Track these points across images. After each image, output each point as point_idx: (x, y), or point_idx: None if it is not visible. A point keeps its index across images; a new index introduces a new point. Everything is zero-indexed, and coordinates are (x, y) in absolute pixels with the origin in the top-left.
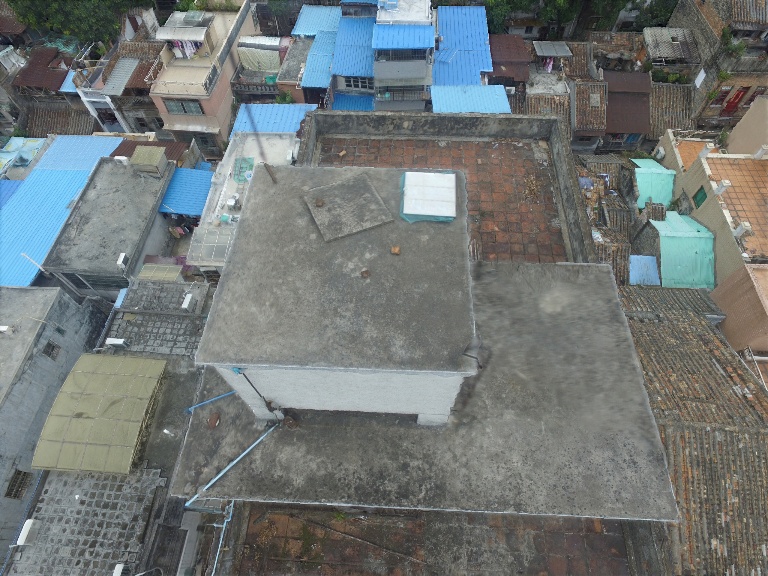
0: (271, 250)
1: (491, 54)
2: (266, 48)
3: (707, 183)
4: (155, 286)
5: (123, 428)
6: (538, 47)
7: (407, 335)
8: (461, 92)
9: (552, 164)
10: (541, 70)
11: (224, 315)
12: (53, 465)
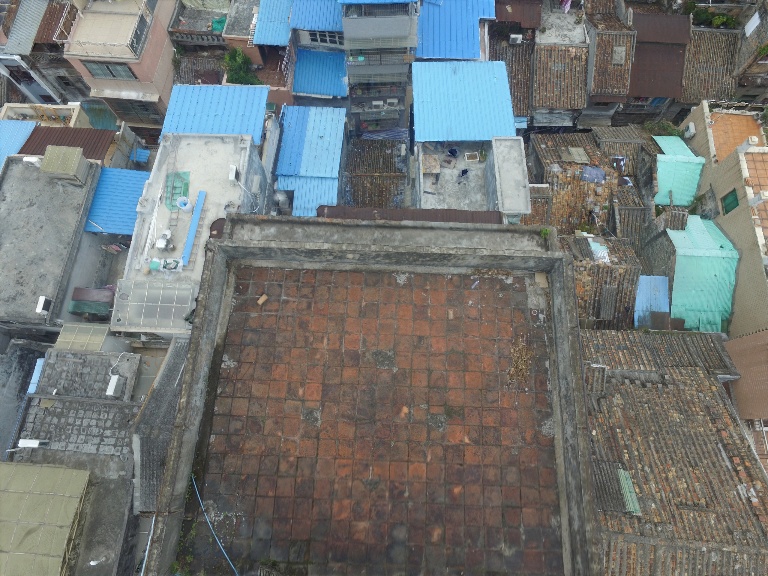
0: None
1: None
2: None
3: (741, 188)
4: (76, 359)
5: (42, 564)
6: None
7: None
8: (450, 73)
9: (551, 317)
10: (556, 9)
11: None
12: None
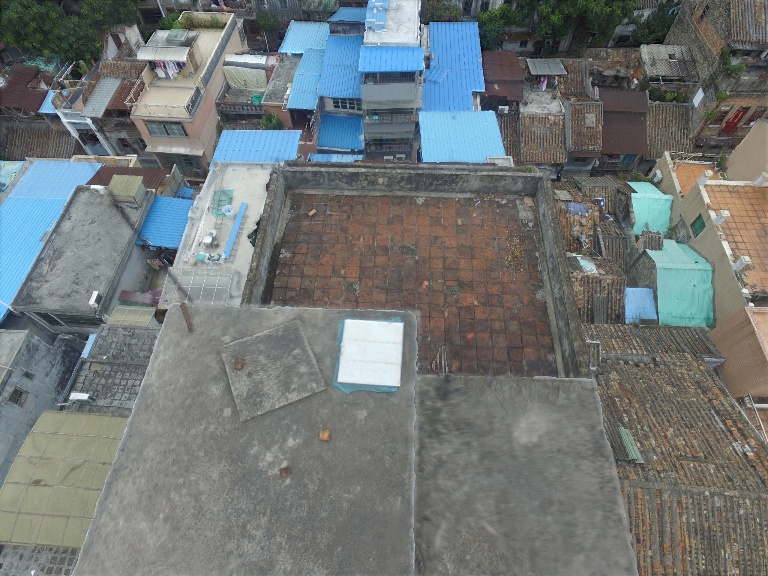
0: (175, 433)
1: (484, 72)
2: (252, 67)
3: (705, 212)
4: (125, 332)
5: (83, 497)
6: (532, 65)
7: (329, 567)
8: (450, 118)
9: (538, 225)
10: (535, 88)
11: (106, 533)
12: (7, 539)
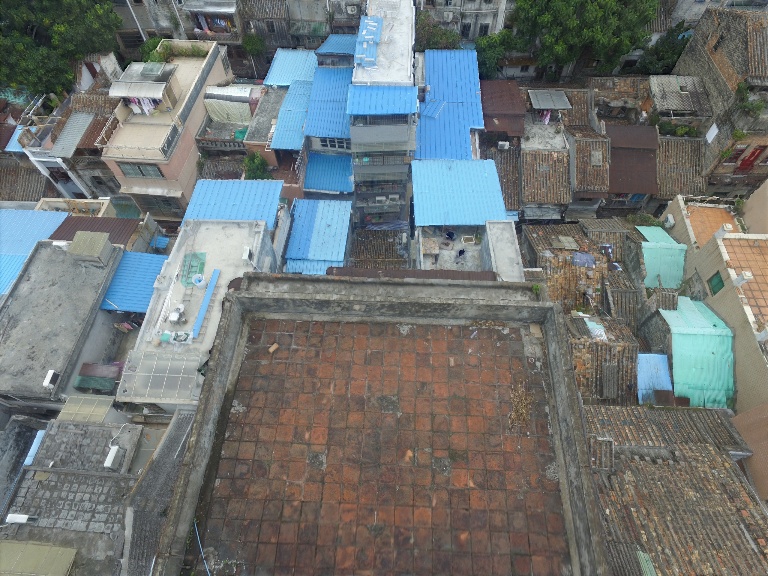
0: None
1: (482, 105)
2: (235, 100)
3: (724, 270)
4: (77, 430)
5: None
6: (534, 97)
7: None
8: (446, 169)
9: (547, 364)
10: (537, 121)
11: None
12: None
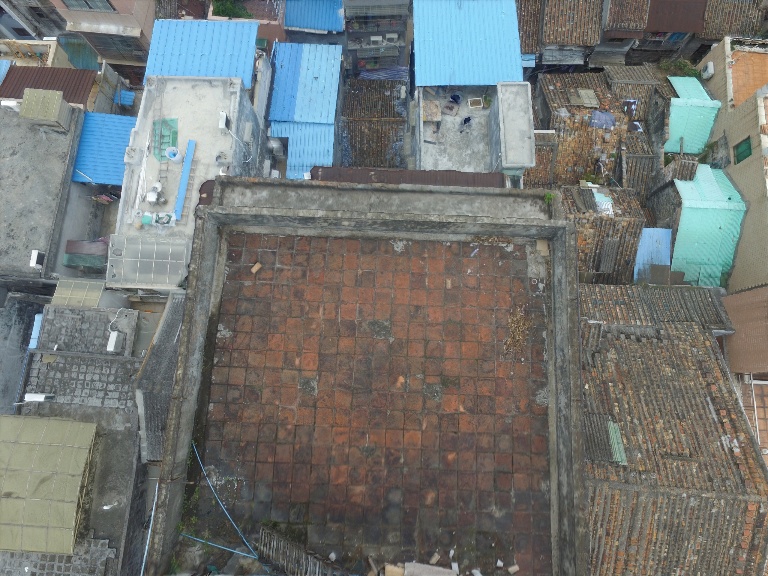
0: None
1: None
2: None
3: (756, 136)
4: (74, 315)
5: (58, 509)
6: None
7: None
8: (455, 7)
9: (550, 286)
10: None
11: None
12: None
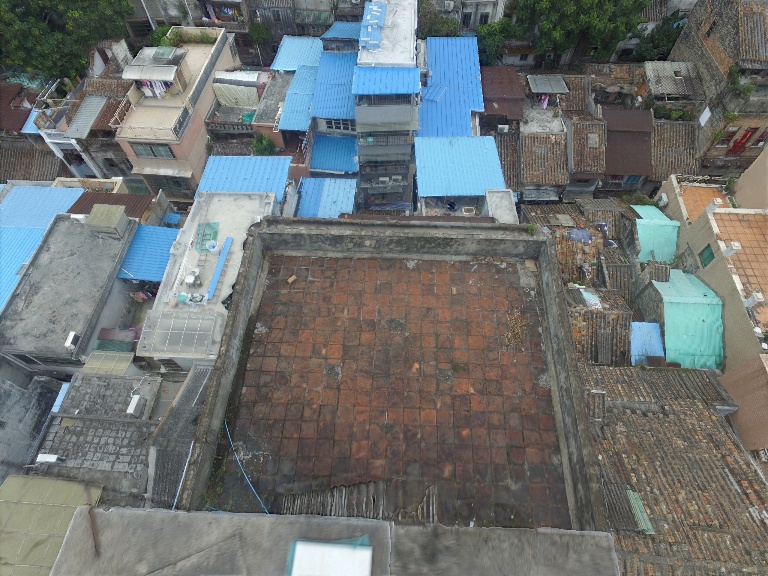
0: None
1: (483, 90)
2: (243, 84)
3: (715, 242)
4: (100, 382)
5: None
6: (533, 82)
7: None
8: (447, 145)
9: (541, 293)
10: (536, 106)
11: None
12: None
